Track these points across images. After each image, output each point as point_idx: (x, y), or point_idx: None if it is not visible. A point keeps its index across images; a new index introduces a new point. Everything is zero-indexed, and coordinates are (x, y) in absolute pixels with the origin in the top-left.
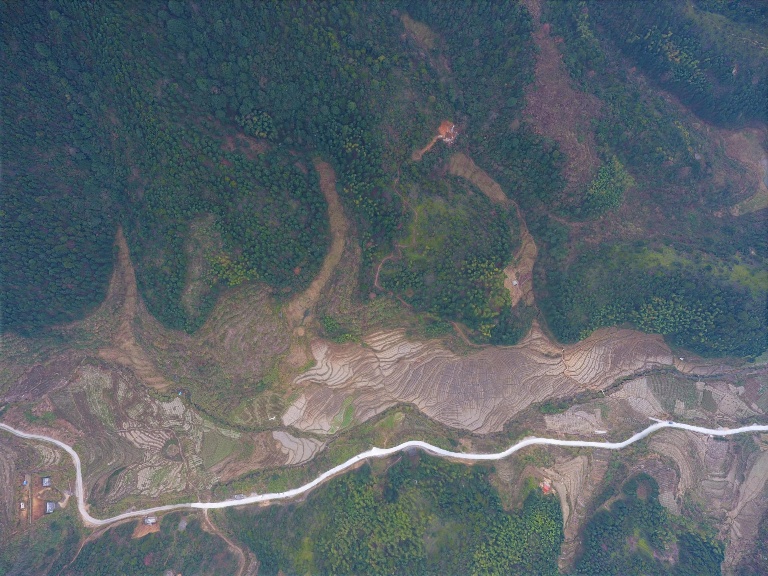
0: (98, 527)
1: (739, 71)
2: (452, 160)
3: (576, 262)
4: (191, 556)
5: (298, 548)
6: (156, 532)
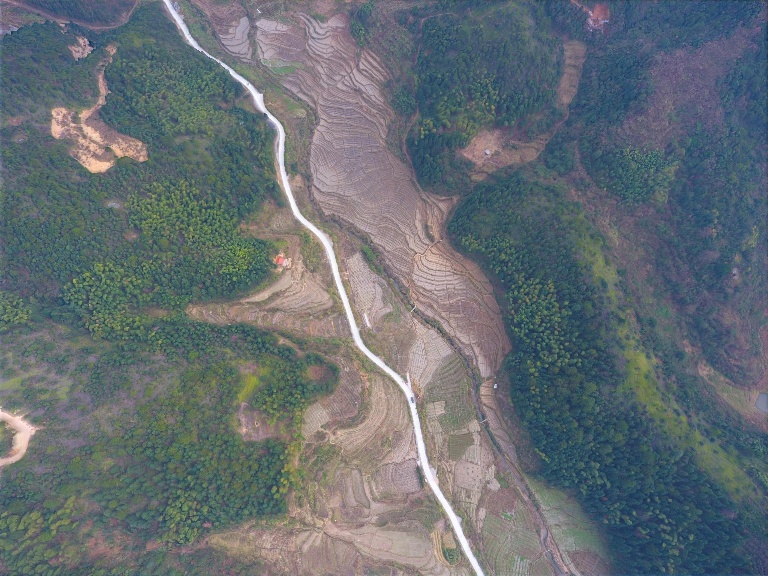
0: None
1: None
2: (575, 42)
3: None
4: None
5: (143, 31)
6: None
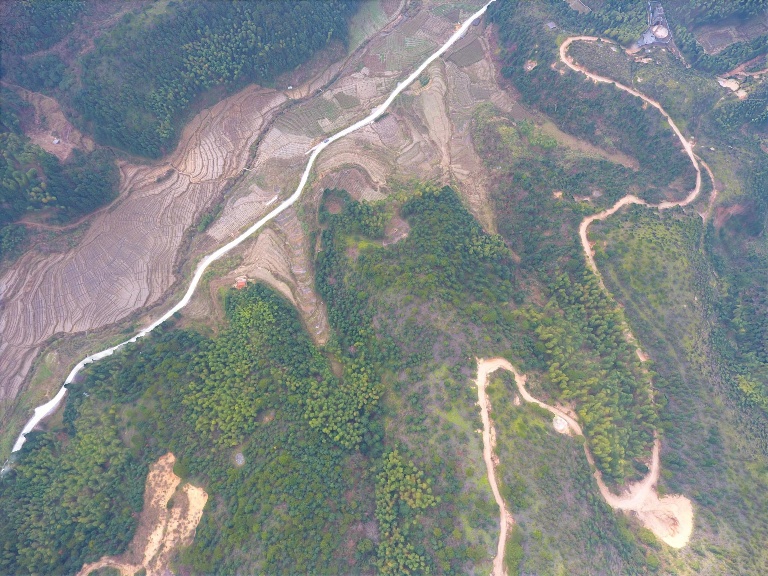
0: None
1: None
2: None
3: None
4: None
5: None
6: None
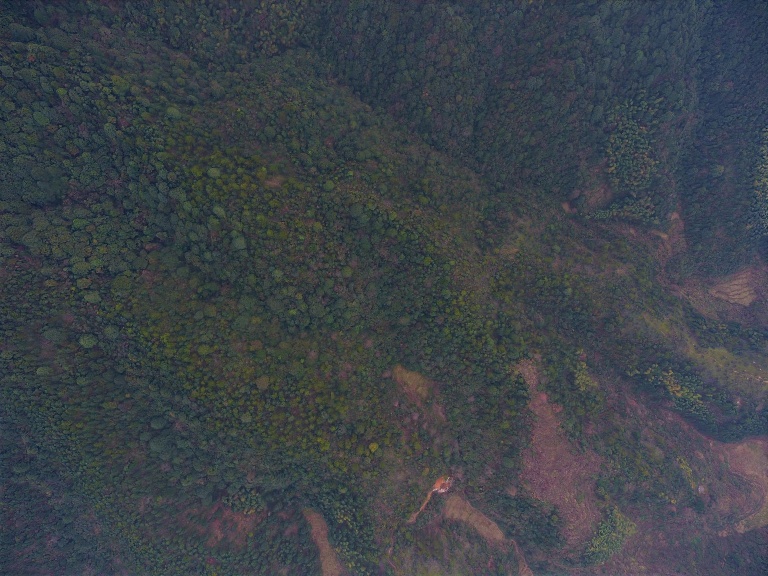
0: None
1: (742, 404)
2: (448, 503)
3: None
4: None
5: None
6: None
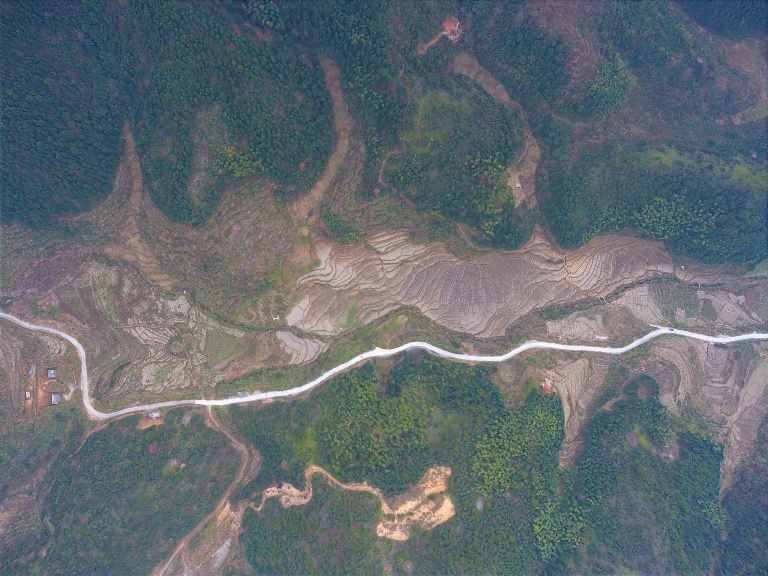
0: (103, 420)
1: None
2: (456, 60)
3: (579, 161)
4: (195, 448)
5: (301, 436)
6: (160, 424)
